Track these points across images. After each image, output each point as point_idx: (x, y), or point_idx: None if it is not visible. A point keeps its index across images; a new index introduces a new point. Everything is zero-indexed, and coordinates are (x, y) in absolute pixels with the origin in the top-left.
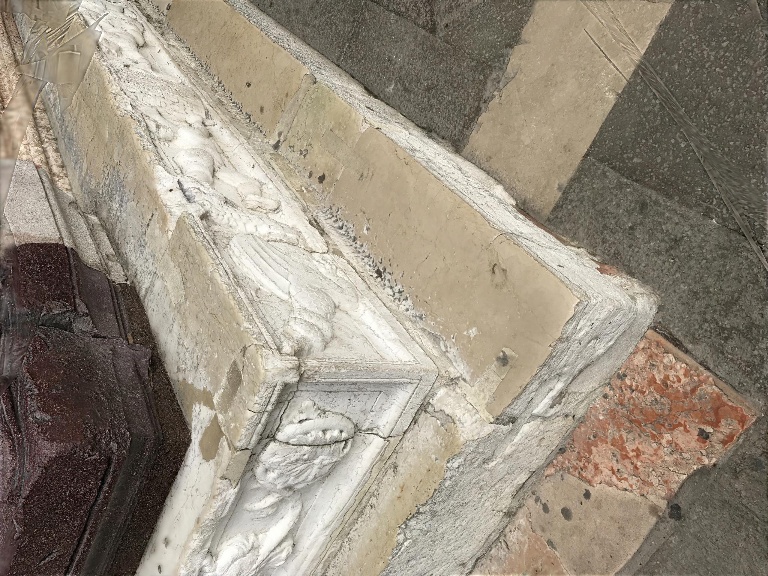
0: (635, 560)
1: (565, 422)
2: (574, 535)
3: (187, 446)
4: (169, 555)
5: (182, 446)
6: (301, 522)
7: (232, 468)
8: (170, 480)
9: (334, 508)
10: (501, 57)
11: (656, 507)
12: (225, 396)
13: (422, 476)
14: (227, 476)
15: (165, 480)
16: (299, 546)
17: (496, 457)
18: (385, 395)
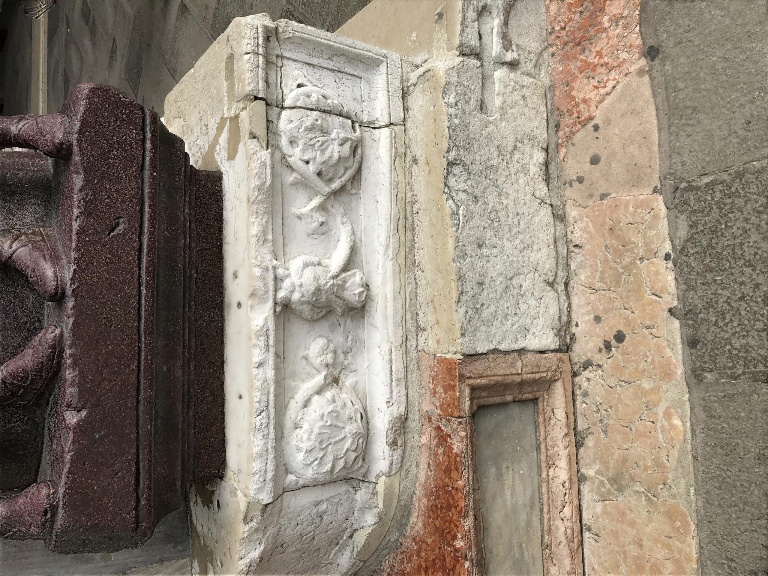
0: (660, 117)
1: (534, 81)
2: (611, 163)
3: (221, 180)
4: (241, 276)
5: (216, 180)
6: (361, 253)
7: (254, 121)
8: (219, 225)
9: (383, 222)
10: (367, 2)
11: (640, 68)
12: (229, 92)
13: (433, 131)
14: (253, 131)
15: (214, 224)
16: (374, 289)
17: (491, 112)
18: (366, 83)
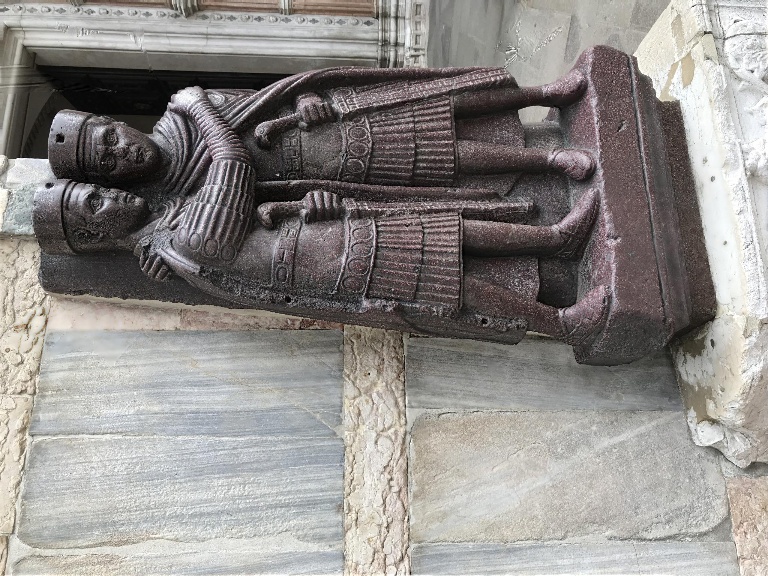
0: None
1: None
2: None
3: (679, 105)
4: (711, 158)
5: (675, 106)
6: None
7: (707, 48)
8: (682, 135)
9: None
10: None
11: None
12: (679, 42)
13: None
14: (707, 54)
15: (678, 135)
16: None
17: None
18: None
